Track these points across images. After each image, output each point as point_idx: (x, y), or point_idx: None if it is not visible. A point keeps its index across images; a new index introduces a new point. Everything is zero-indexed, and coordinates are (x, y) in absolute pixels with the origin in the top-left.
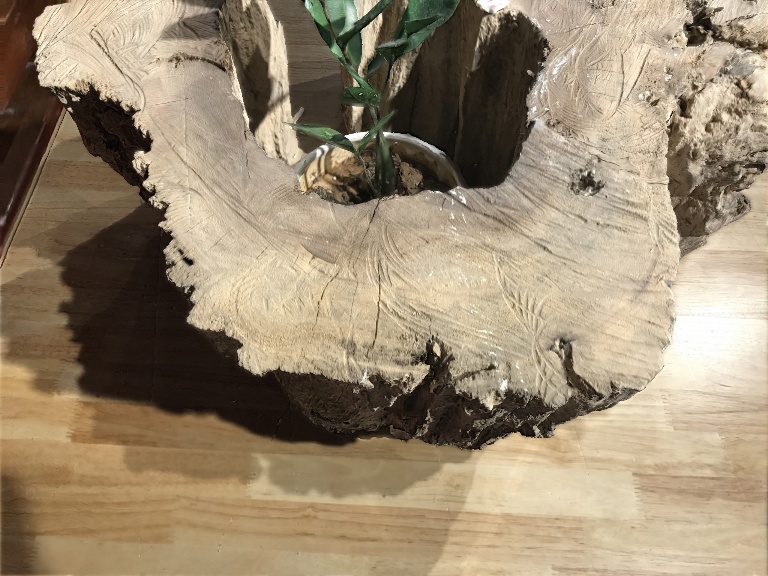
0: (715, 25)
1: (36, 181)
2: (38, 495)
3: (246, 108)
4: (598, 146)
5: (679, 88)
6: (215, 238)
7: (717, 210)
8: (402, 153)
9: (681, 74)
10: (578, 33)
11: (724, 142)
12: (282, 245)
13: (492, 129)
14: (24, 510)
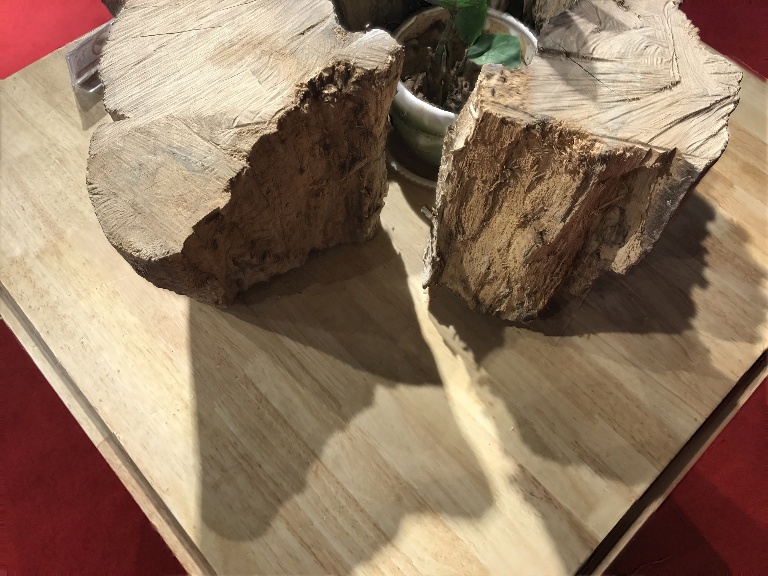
0: None
1: (675, 479)
2: (767, 168)
3: None
4: None
5: None
6: None
7: None
8: None
9: None
10: None
11: None
12: None
13: None
14: None
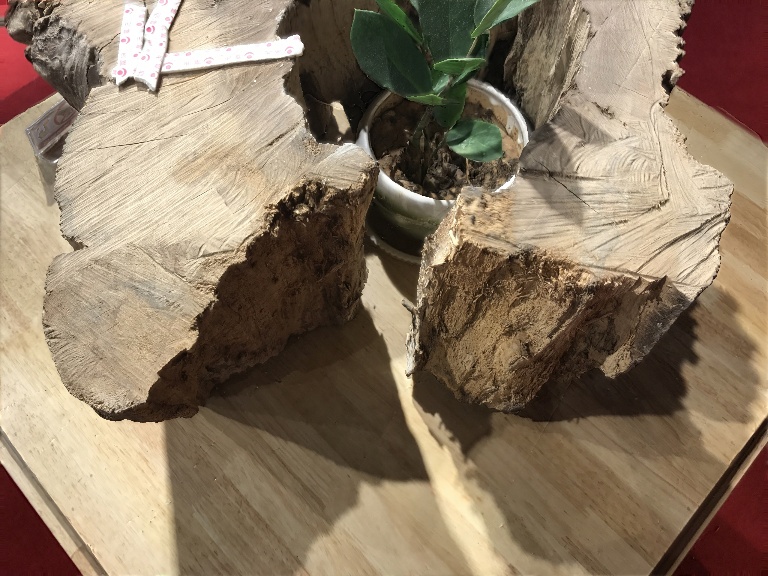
0: None
1: (669, 571)
2: (755, 230)
3: None
4: None
5: None
6: None
7: None
8: None
9: None
10: None
11: None
12: None
13: None
14: (767, 230)
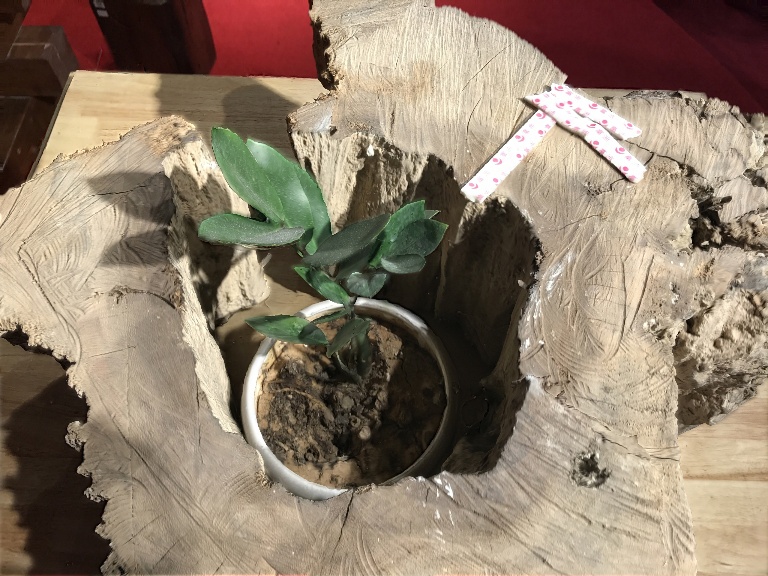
0: (724, 223)
1: None
2: None
3: (206, 273)
4: (600, 399)
5: (687, 312)
6: (162, 550)
7: (723, 408)
8: (379, 316)
9: (689, 294)
10: (573, 230)
11: (734, 359)
12: (240, 559)
13: (477, 289)
14: None
